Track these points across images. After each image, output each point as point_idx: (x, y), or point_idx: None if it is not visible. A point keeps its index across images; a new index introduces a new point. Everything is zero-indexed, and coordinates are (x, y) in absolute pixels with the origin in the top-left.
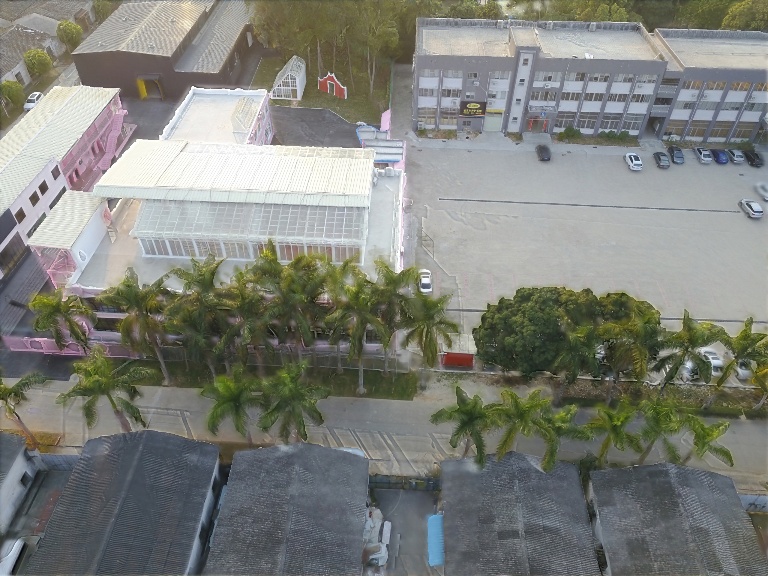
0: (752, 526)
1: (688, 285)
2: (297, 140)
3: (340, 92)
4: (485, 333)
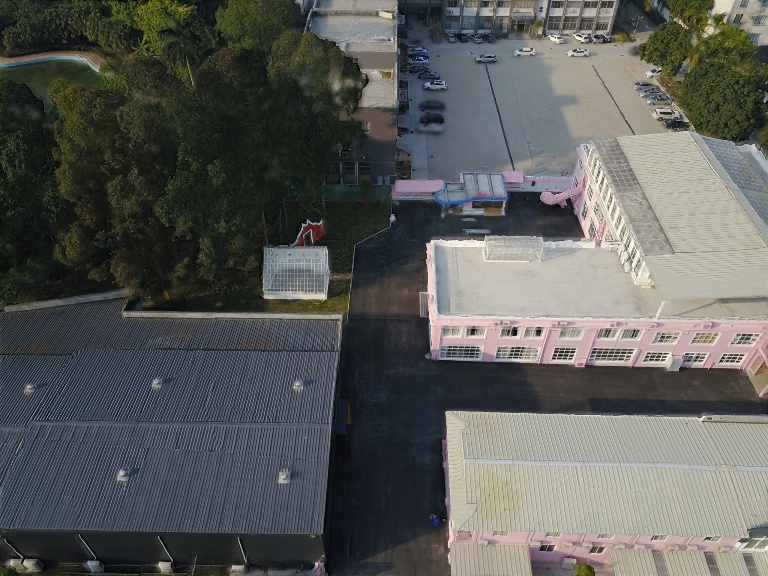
0: None
1: (579, 92)
2: None
3: (317, 233)
4: None
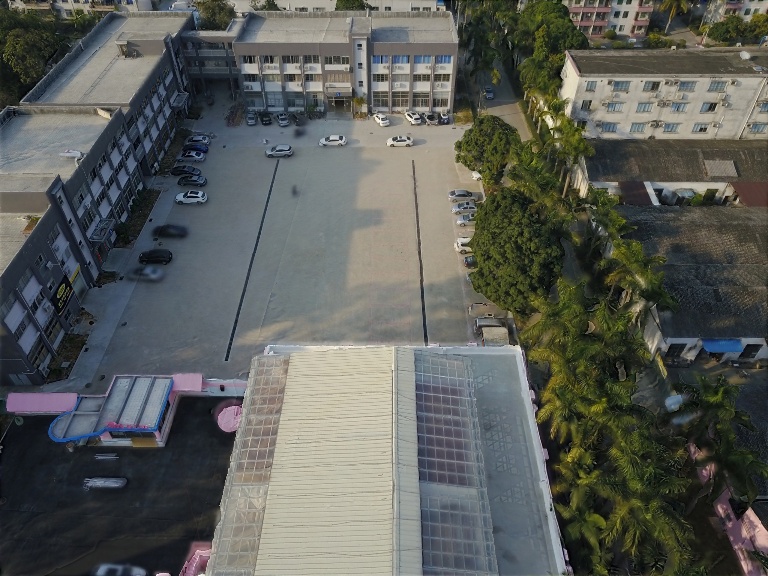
0: (632, 205)
1: (377, 204)
2: (9, 561)
3: None
4: (542, 289)
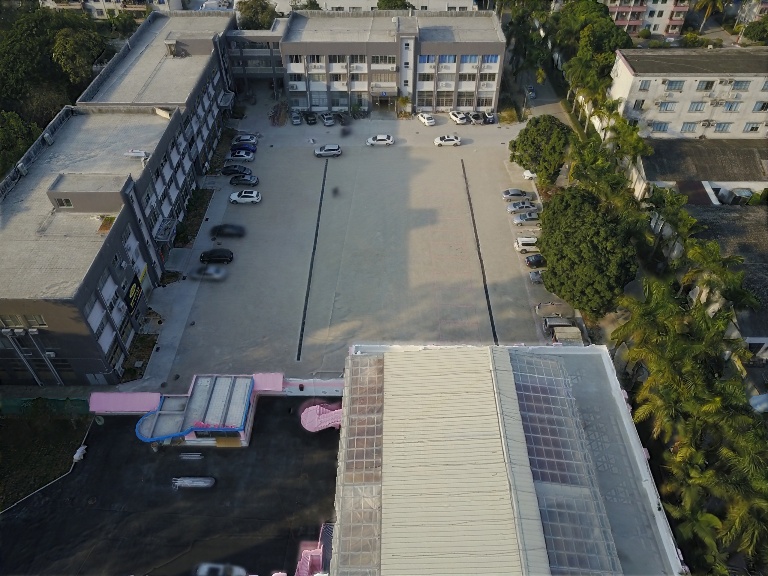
0: (694, 204)
1: (431, 203)
2: (107, 561)
3: None
4: None
